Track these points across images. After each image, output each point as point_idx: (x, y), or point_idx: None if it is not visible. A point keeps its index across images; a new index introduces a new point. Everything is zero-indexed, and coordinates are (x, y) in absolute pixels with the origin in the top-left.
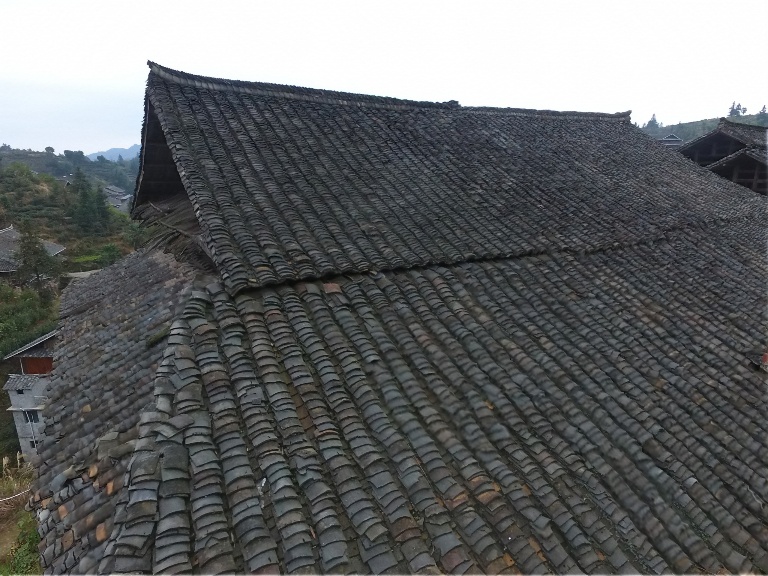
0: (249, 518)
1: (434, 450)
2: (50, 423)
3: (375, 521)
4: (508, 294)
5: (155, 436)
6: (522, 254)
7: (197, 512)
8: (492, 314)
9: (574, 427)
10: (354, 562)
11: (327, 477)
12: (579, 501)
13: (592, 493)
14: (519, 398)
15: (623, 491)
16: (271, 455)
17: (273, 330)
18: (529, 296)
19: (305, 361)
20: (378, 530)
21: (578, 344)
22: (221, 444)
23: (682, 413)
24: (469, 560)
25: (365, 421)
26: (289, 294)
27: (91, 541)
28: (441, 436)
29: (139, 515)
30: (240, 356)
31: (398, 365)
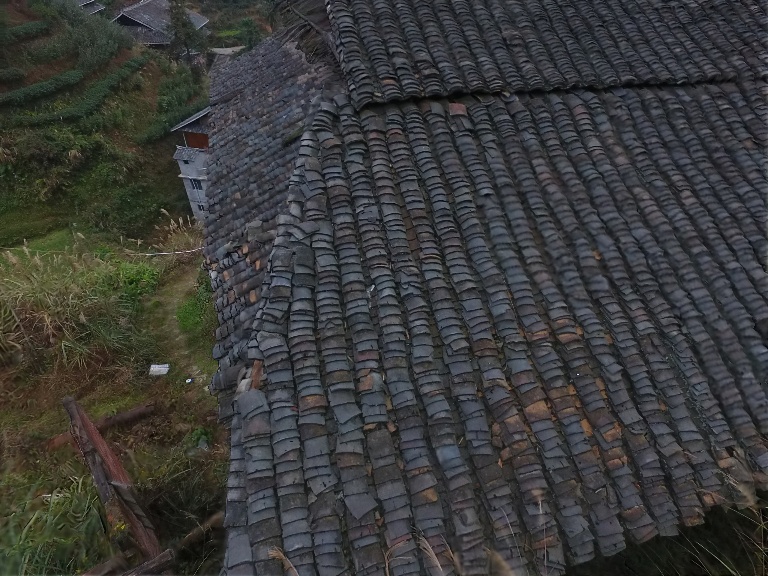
0: (359, 314)
1: (527, 289)
2: (211, 203)
3: (460, 336)
4: (662, 133)
5: (289, 236)
6: (700, 80)
7: (320, 301)
8: (633, 156)
9: (684, 291)
10: (437, 362)
11: (425, 294)
12: (660, 359)
13: (677, 355)
14: (632, 253)
15: (712, 360)
16: (380, 268)
17: (393, 151)
18: (688, 138)
19: (420, 186)
20: (461, 344)
21: (728, 204)
22: (340, 251)
23: None
24: (535, 382)
25: (467, 251)
26: (412, 113)
27: (247, 301)
28: (537, 277)
29: (278, 295)
30: (361, 174)
31: (511, 202)
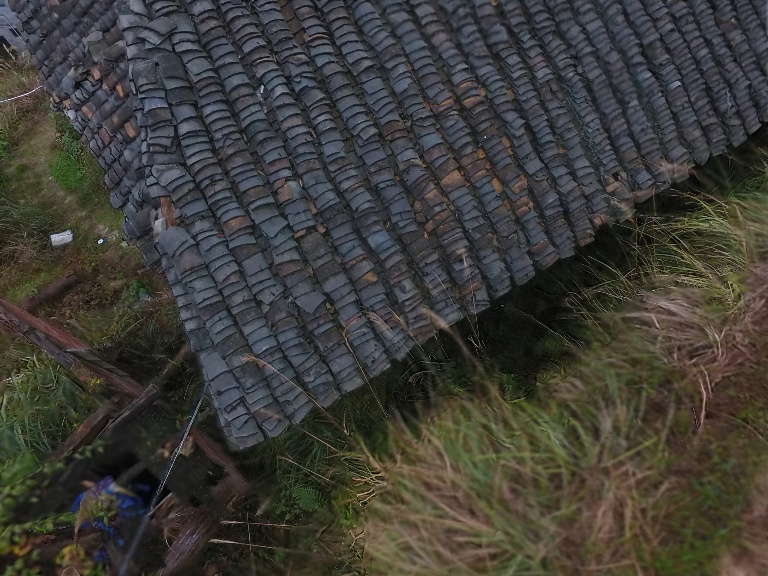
0: (255, 122)
1: (426, 55)
2: (24, 19)
3: (367, 124)
4: None
5: (142, 43)
6: None
7: (208, 117)
8: None
9: (579, 27)
10: (350, 156)
11: (321, 84)
12: (558, 105)
13: (573, 97)
14: None
15: (604, 95)
16: (264, 62)
17: None
18: None
19: None
20: (370, 131)
21: None
22: (211, 51)
23: (706, 8)
24: (447, 154)
25: (356, 23)
26: None
27: (125, 137)
28: (435, 39)
29: (158, 120)
30: None
31: None
